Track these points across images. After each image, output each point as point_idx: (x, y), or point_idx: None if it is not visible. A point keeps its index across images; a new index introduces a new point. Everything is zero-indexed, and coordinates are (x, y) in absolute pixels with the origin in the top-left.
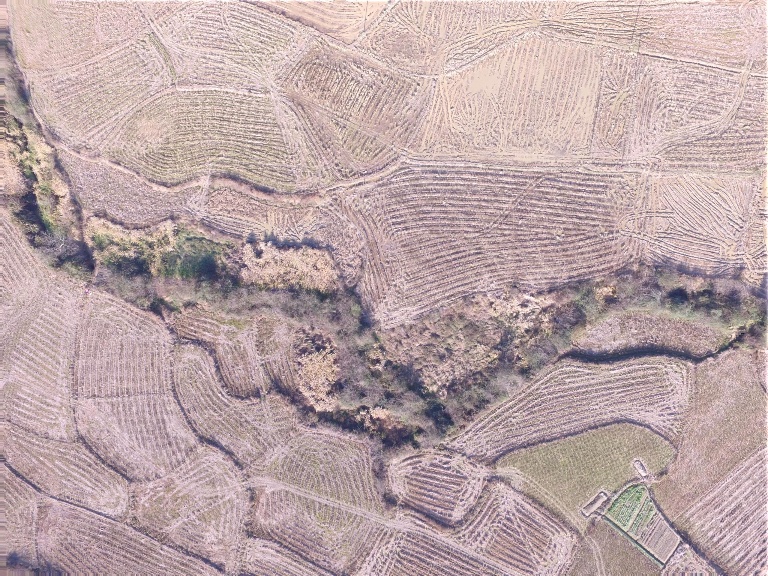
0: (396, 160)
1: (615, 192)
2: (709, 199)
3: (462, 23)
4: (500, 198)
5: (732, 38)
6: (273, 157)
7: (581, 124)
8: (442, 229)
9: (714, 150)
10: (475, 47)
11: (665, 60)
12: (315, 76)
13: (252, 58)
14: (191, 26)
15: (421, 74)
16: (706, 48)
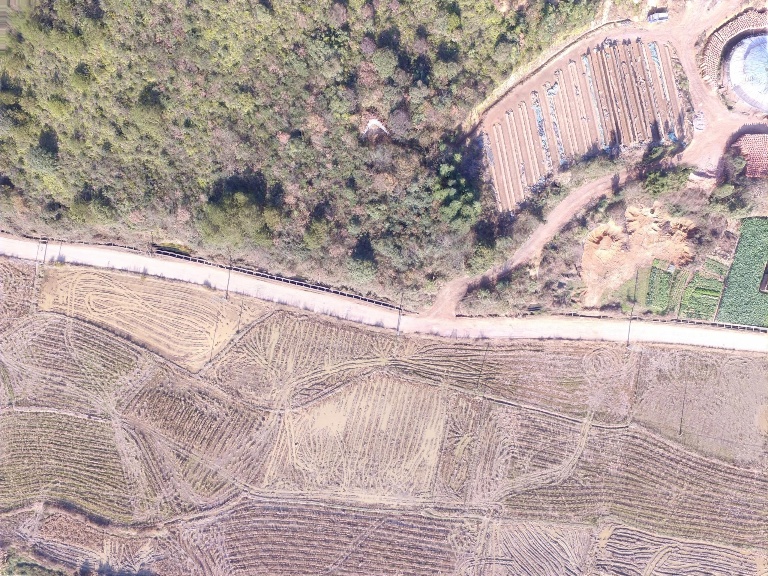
0: (237, 496)
1: (456, 537)
2: (548, 548)
3: (310, 358)
4: (341, 539)
5: (575, 388)
6: (111, 486)
7: (425, 467)
8: (281, 569)
9: (554, 500)
10: (322, 383)
11: (510, 406)
12: (158, 405)
13: (94, 382)
14: (33, 344)
15: (266, 408)
16: (549, 397)
